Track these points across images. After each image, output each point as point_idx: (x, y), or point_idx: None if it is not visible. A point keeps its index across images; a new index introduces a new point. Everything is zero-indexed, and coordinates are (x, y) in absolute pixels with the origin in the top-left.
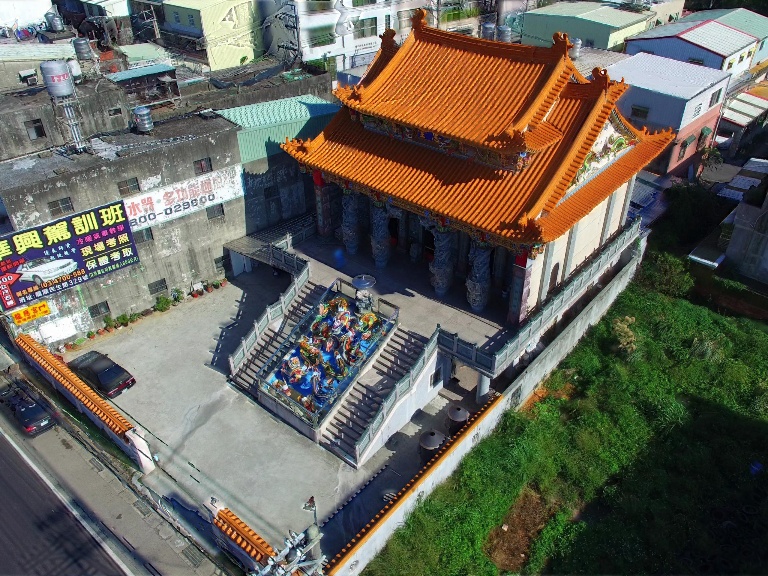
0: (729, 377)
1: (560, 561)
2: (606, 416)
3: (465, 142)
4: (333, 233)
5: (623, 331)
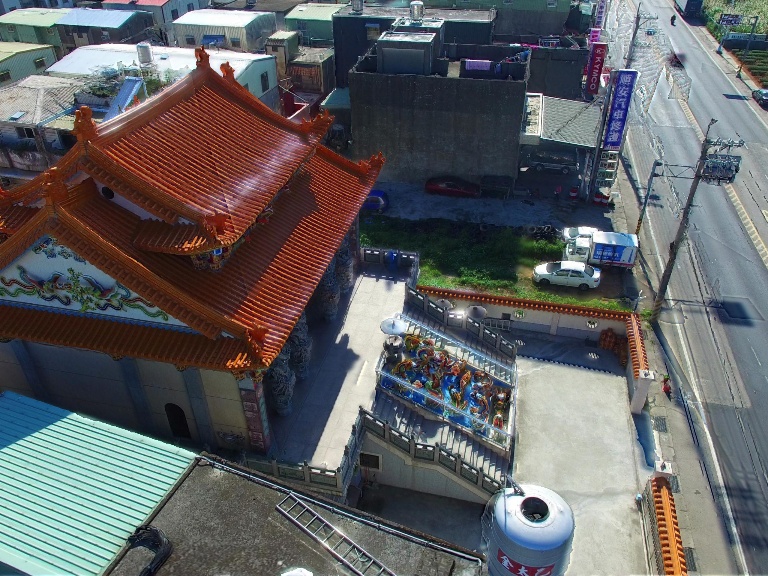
0: None
1: None
2: None
3: None
4: None
5: None
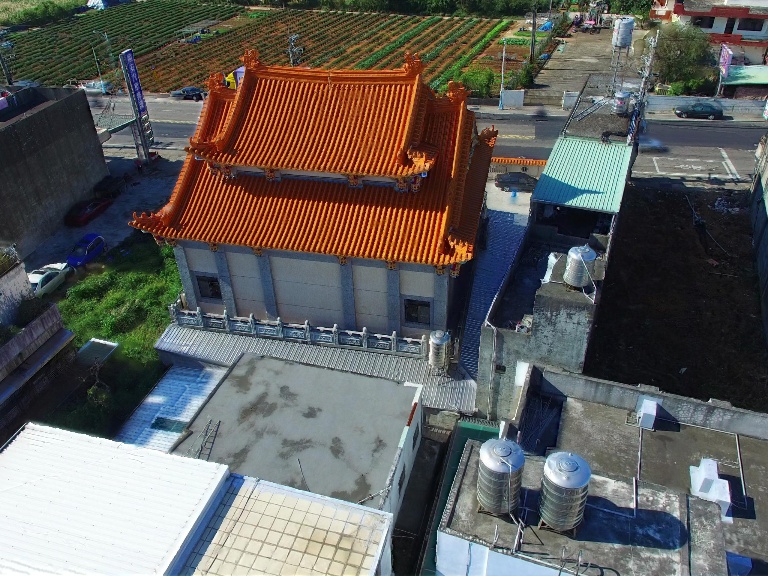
0: None
1: None
2: None
3: None
4: None
5: None
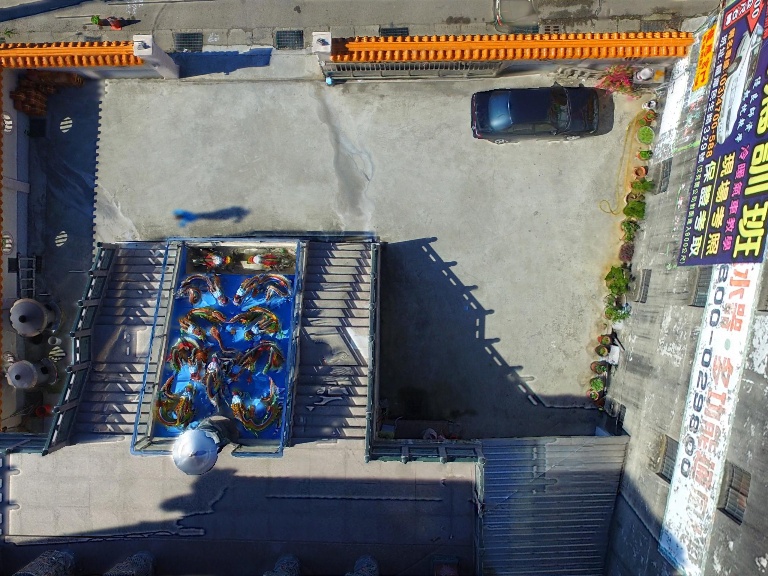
0: None
1: None
2: None
3: None
4: None
5: None
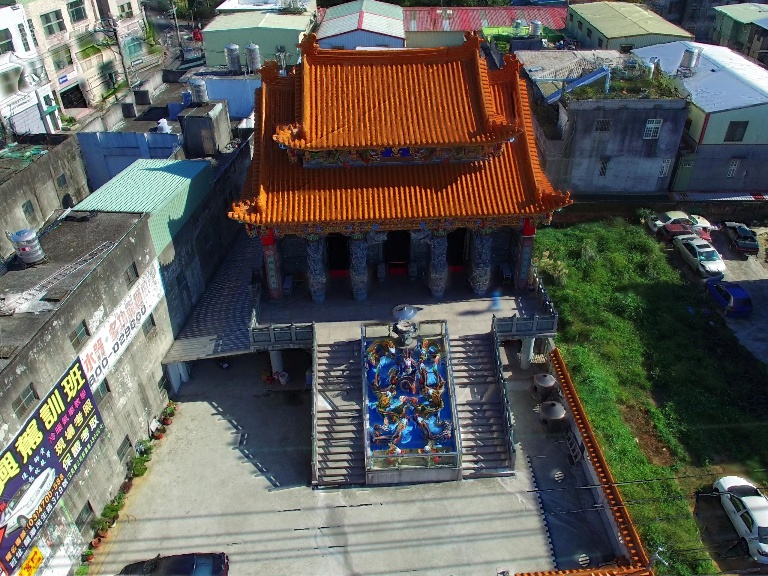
0: (620, 265)
1: (688, 435)
2: (599, 328)
3: (450, 145)
4: (282, 291)
5: (548, 265)
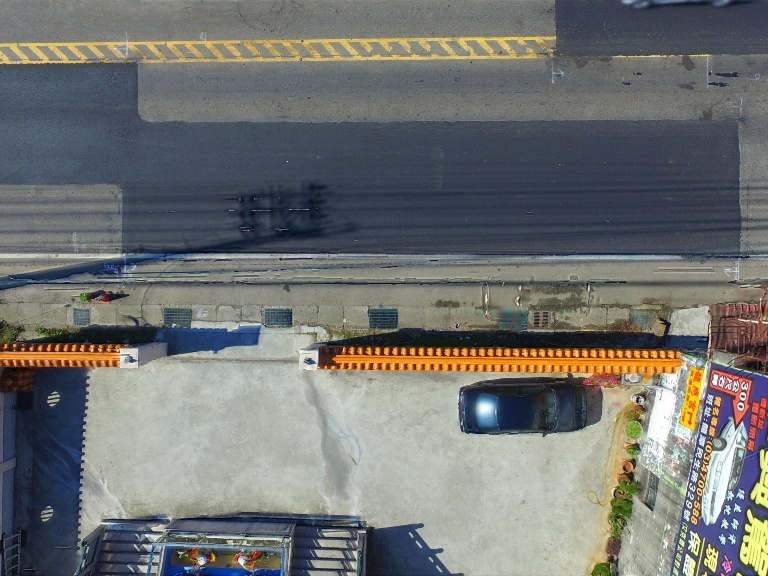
0: None
1: None
2: None
3: None
4: None
5: None
